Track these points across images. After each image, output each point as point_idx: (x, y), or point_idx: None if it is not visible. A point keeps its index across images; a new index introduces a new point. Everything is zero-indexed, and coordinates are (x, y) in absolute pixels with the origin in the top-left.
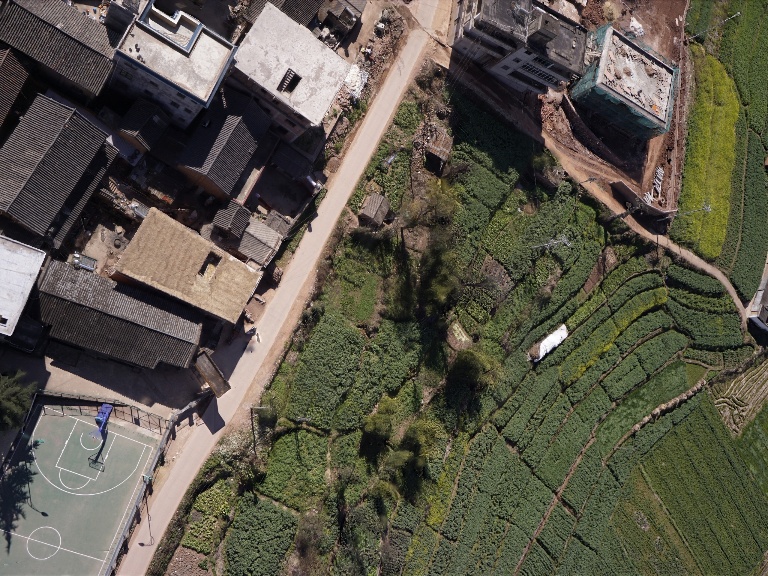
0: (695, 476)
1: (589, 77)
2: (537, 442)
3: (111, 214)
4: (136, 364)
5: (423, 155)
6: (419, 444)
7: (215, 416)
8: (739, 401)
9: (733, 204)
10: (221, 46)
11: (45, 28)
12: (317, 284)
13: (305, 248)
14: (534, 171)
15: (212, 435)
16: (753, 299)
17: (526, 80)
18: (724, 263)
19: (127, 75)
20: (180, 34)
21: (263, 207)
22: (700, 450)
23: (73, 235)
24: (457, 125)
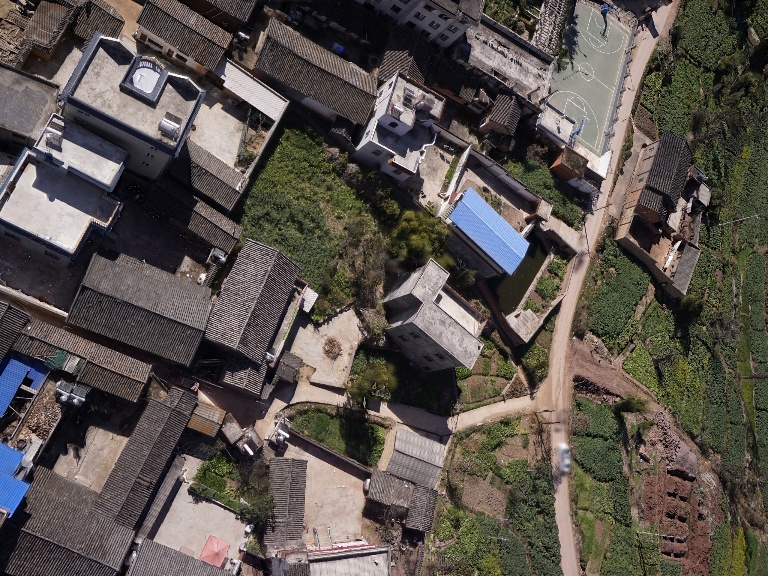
0: None
1: None
2: None
3: None
4: None
5: None
6: (747, 87)
7: (653, 29)
8: None
9: None
10: None
11: None
12: None
13: None
14: None
15: (653, 39)
16: None
17: None
18: None
19: None
20: None
21: None
22: None
23: None
24: None
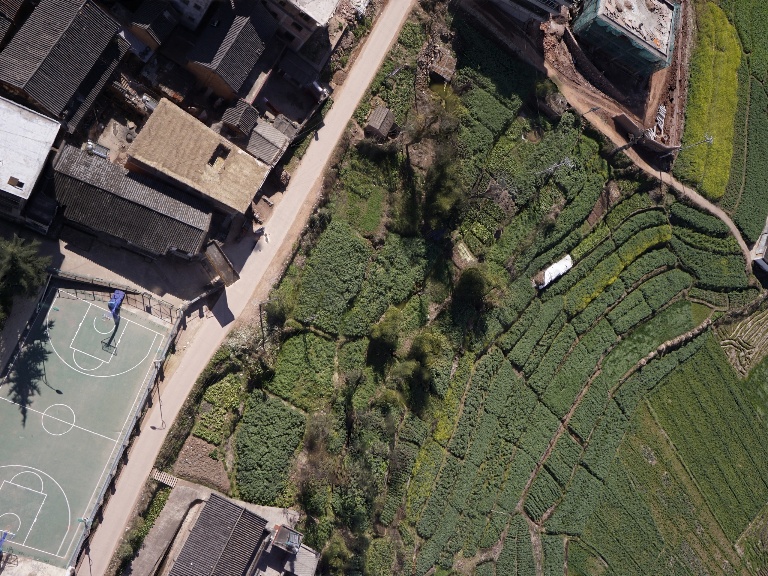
0: (702, 414)
1: (590, 10)
2: (543, 369)
3: (123, 109)
4: (147, 253)
5: (427, 76)
6: (425, 354)
7: (225, 310)
8: (745, 343)
9: (736, 148)
10: None
11: None
12: (324, 191)
13: (312, 155)
14: None
15: (222, 328)
16: (758, 242)
17: (528, 6)
18: (728, 204)
19: None
20: None
21: (271, 113)
22: (706, 389)
23: (86, 126)
24: (460, 50)
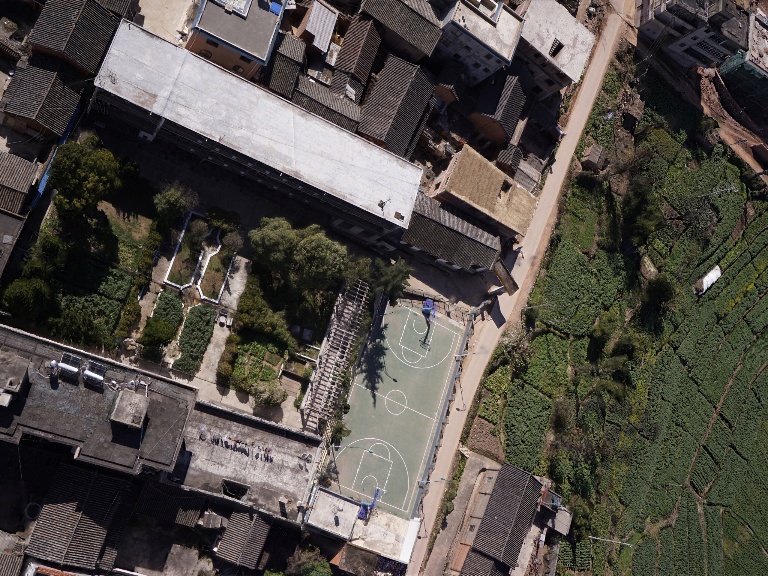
0: None
1: (737, 55)
2: (701, 364)
3: (423, 152)
4: (447, 269)
5: (621, 116)
6: (632, 350)
7: (499, 314)
8: None
9: None
10: (515, 19)
11: (397, 4)
12: (558, 215)
13: (549, 186)
14: (703, 131)
15: (498, 329)
16: None
17: (696, 56)
18: None
19: (445, 42)
20: None
21: None
22: None
23: None
24: (641, 93)
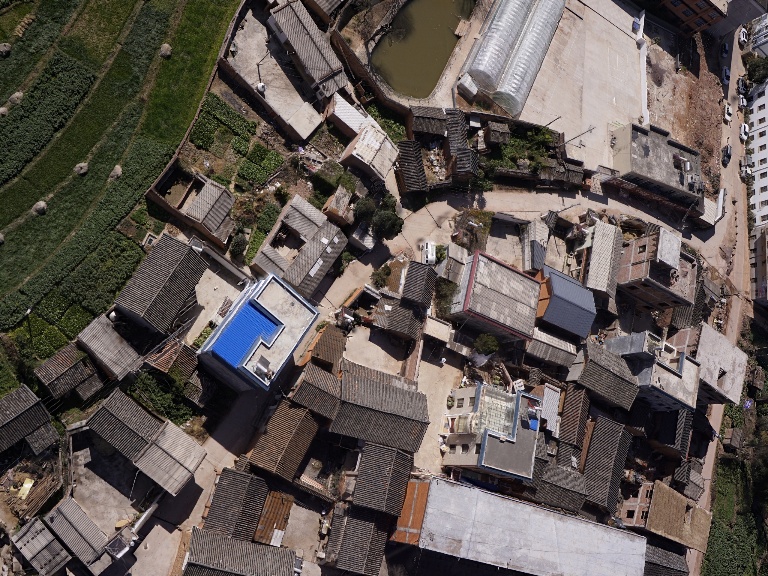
0: None
1: None
2: None
3: None
4: None
5: (746, 387)
6: None
7: None
8: None
9: None
10: (694, 365)
11: (605, 373)
12: (712, 502)
13: None
14: None
15: None
16: None
17: None
18: None
19: None
20: (662, 356)
21: None
22: None
23: None
24: None
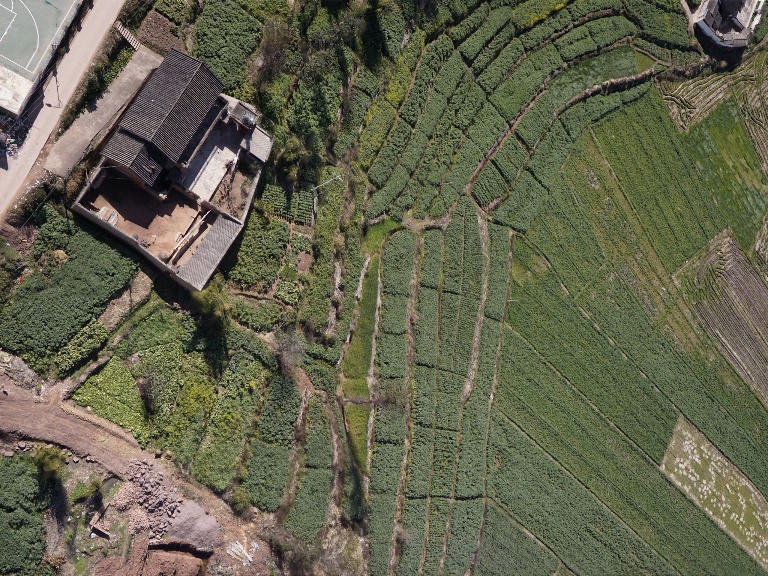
0: (644, 155)
1: None
2: (491, 71)
3: None
4: None
5: None
6: None
7: None
8: (687, 103)
9: None
10: None
11: None
12: None
13: None
14: None
15: None
16: (700, 8)
17: None
18: None
19: None
20: None
21: None
22: (649, 134)
23: None
24: None
